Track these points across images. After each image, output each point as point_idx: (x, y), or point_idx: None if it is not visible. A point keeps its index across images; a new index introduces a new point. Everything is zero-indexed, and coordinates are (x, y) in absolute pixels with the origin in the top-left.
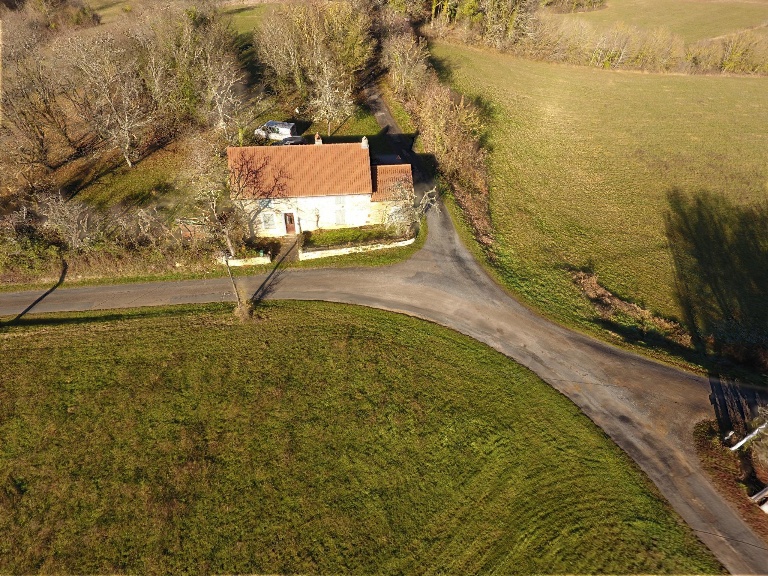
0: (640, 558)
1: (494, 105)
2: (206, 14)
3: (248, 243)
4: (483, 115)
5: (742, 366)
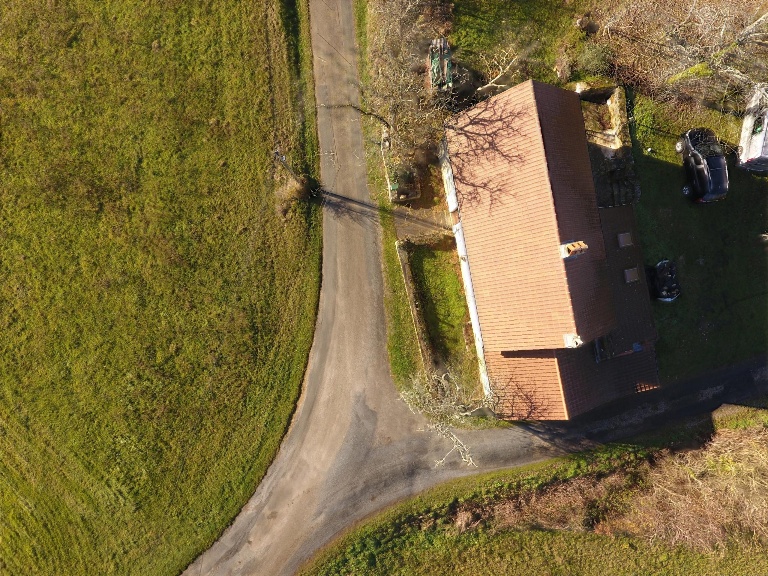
0: None
1: None
2: None
3: (428, 159)
4: None
5: None
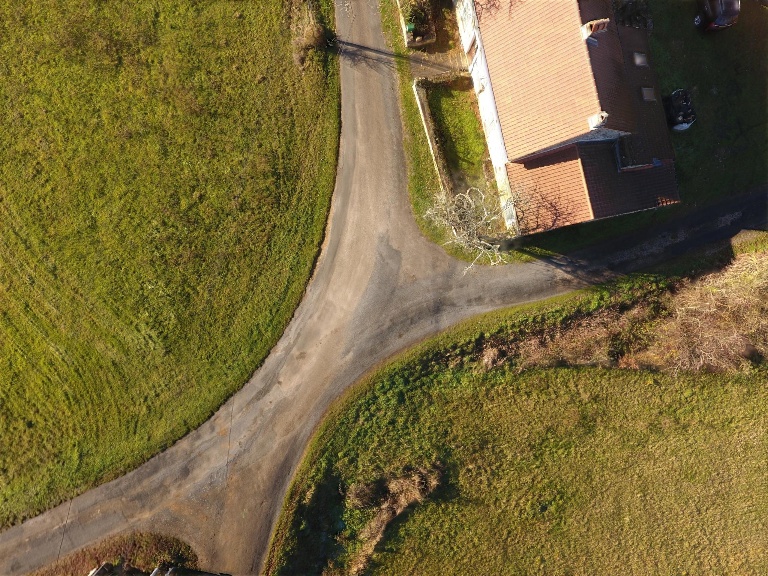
0: (48, 447)
1: None
2: None
3: (442, 3)
4: None
5: None
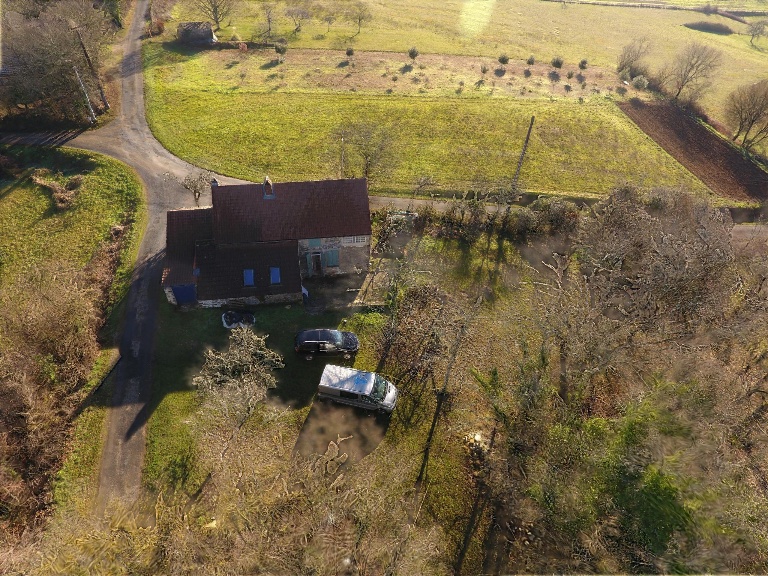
0: None
1: None
2: None
3: None
4: None
5: (21, 164)
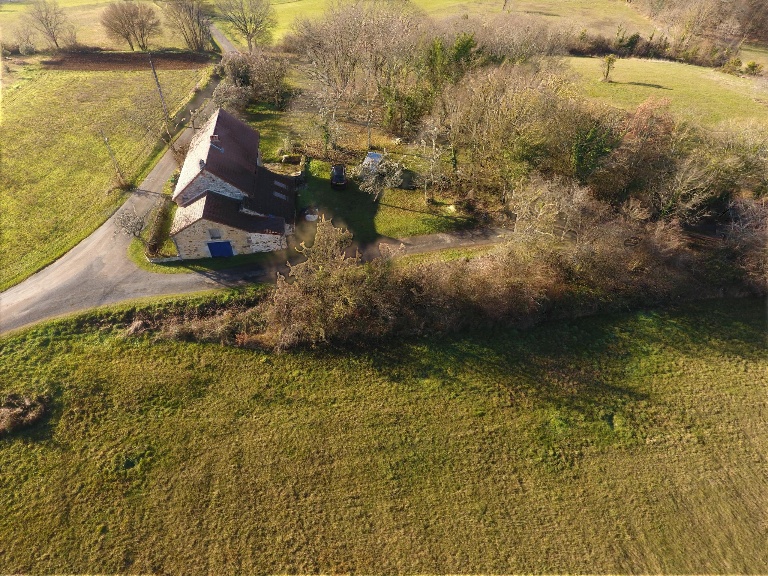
0: None
1: (617, 423)
2: (491, 49)
3: None
4: (541, 388)
5: None
